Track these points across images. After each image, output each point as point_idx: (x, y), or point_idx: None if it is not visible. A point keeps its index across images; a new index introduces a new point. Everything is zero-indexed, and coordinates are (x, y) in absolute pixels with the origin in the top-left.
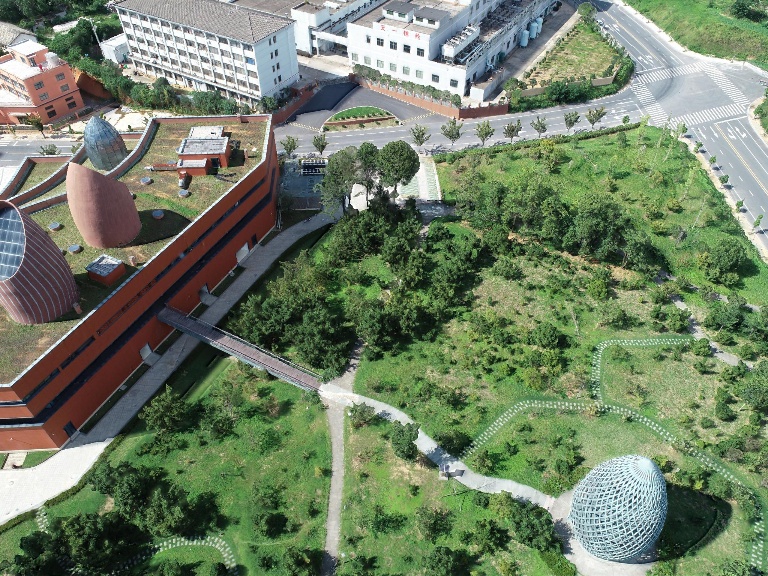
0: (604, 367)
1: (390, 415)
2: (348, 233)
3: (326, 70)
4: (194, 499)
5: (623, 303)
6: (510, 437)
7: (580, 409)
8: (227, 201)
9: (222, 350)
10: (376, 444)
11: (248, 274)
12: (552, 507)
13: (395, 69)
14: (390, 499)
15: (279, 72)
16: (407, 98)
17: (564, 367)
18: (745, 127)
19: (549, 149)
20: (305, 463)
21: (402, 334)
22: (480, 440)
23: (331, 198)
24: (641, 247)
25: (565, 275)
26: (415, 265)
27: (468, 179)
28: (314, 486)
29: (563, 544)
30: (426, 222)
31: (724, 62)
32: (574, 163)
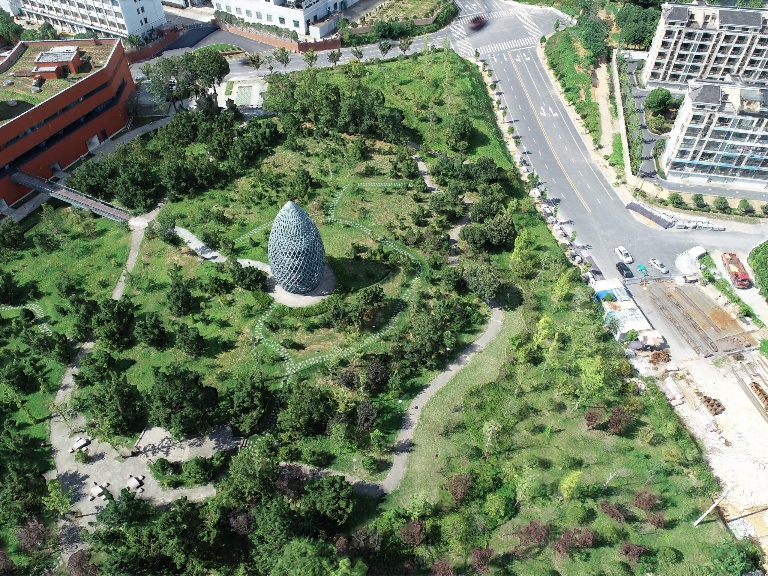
0: (343, 198)
1: (177, 232)
2: (176, 125)
3: (195, 18)
4: (22, 285)
5: (375, 162)
6: (258, 238)
7: (315, 222)
8: (70, 95)
9: (59, 198)
10: (161, 247)
11: (96, 158)
12: (270, 270)
13: (251, 15)
14: (161, 275)
15: (144, 15)
16: (258, 37)
17: (312, 198)
18: (531, 53)
19: (354, 66)
20: (107, 261)
21: (199, 184)
22: (236, 241)
23: (160, 96)
24: (390, 121)
25: (338, 147)
26: (217, 139)
27: (267, 78)
28: (110, 272)
29: (270, 288)
30: (246, 120)
31: (535, 8)
32: (373, 76)
